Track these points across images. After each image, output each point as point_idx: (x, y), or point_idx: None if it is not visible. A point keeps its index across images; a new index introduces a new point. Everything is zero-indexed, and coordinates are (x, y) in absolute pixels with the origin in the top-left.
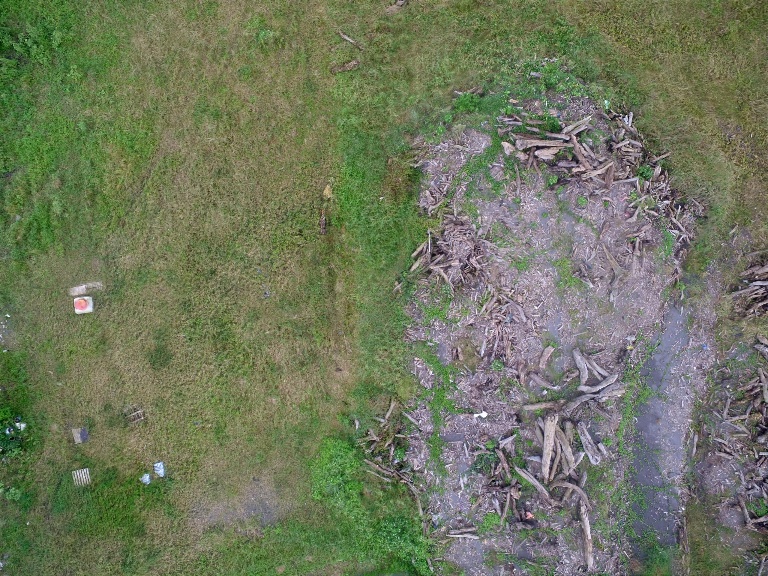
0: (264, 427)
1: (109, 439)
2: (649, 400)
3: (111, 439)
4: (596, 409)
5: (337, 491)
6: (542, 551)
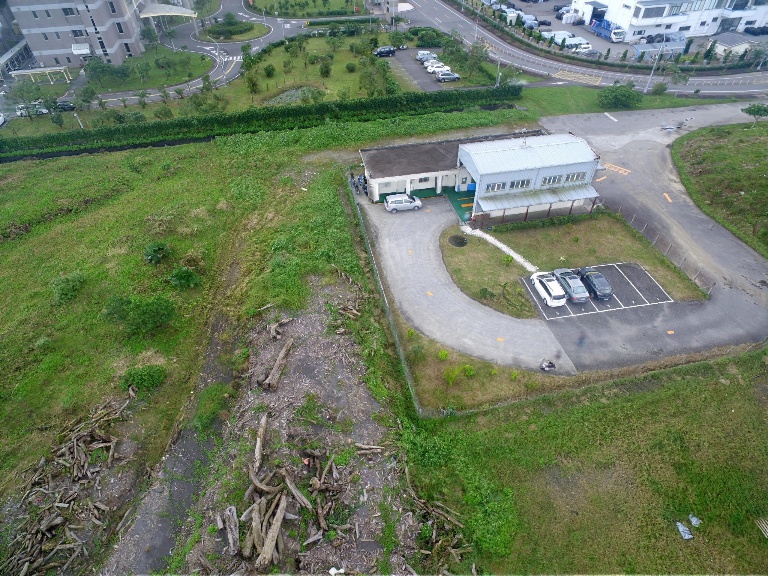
0: (580, 574)
1: (759, 573)
2: (148, 575)
3: (757, 572)
4: (213, 569)
5: (489, 495)
6: (302, 430)
